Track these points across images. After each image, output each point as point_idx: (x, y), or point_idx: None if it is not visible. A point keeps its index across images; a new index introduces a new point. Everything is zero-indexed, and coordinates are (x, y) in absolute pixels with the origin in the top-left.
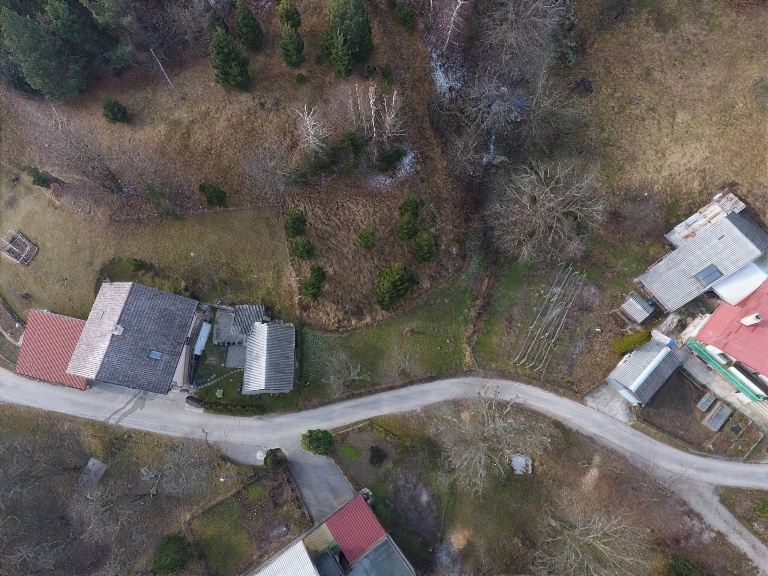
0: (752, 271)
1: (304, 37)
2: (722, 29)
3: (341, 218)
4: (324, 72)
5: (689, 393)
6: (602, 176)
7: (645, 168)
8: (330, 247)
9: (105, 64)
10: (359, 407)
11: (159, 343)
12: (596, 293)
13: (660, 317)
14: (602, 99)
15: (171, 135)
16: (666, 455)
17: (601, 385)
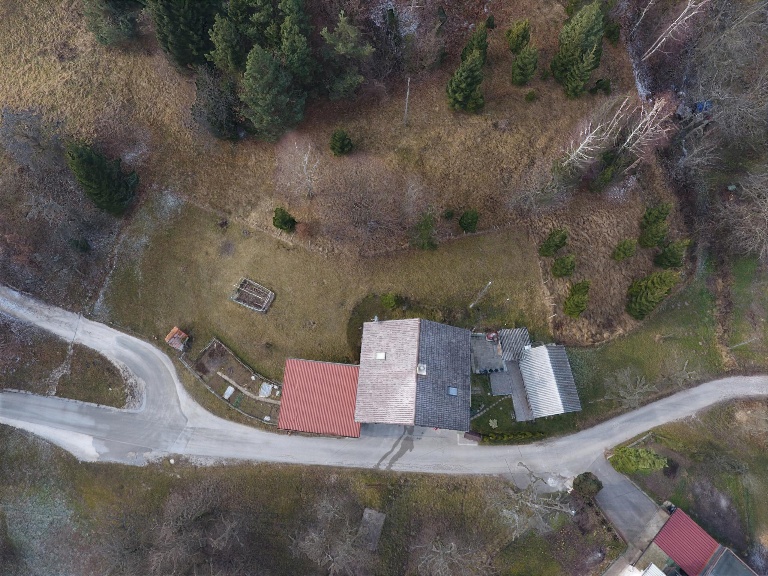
0: None
1: None
2: None
3: (589, 232)
4: (550, 89)
5: None
6: None
7: None
8: (582, 262)
9: None
10: (636, 420)
11: (452, 378)
12: None
13: None
14: None
15: (405, 164)
16: None
17: None
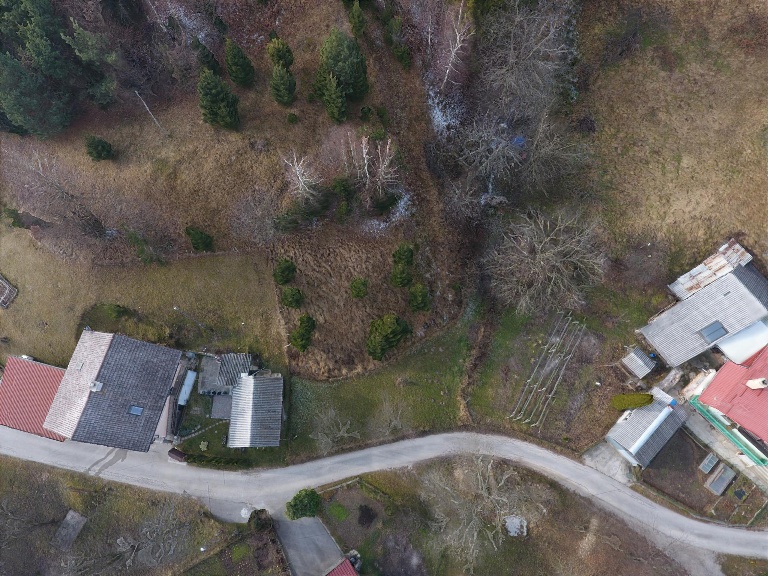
0: (758, 329)
1: (297, 74)
2: (730, 70)
3: (332, 265)
4: (317, 112)
5: (691, 453)
6: (604, 221)
7: (648, 214)
8: (321, 295)
9: (90, 98)
10: (348, 463)
11: (140, 398)
12: (596, 344)
13: (662, 371)
14: (605, 139)
15: (157, 175)
16: (666, 520)
17: (600, 443)
